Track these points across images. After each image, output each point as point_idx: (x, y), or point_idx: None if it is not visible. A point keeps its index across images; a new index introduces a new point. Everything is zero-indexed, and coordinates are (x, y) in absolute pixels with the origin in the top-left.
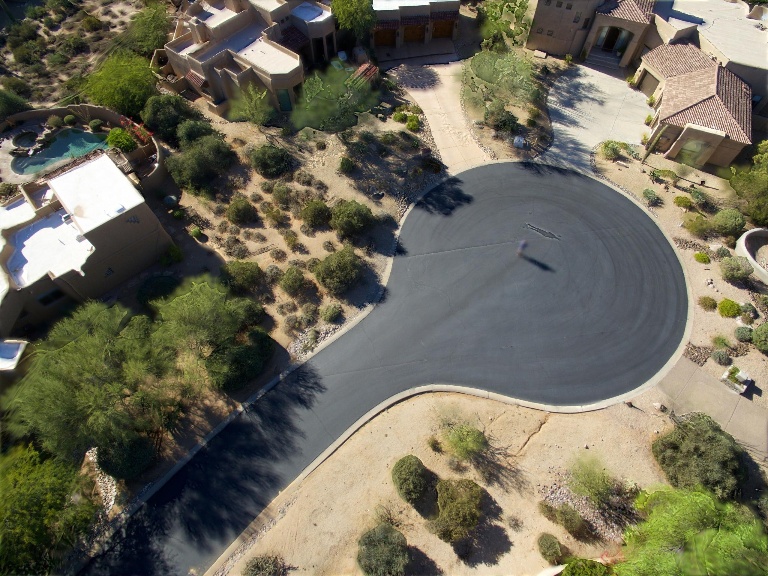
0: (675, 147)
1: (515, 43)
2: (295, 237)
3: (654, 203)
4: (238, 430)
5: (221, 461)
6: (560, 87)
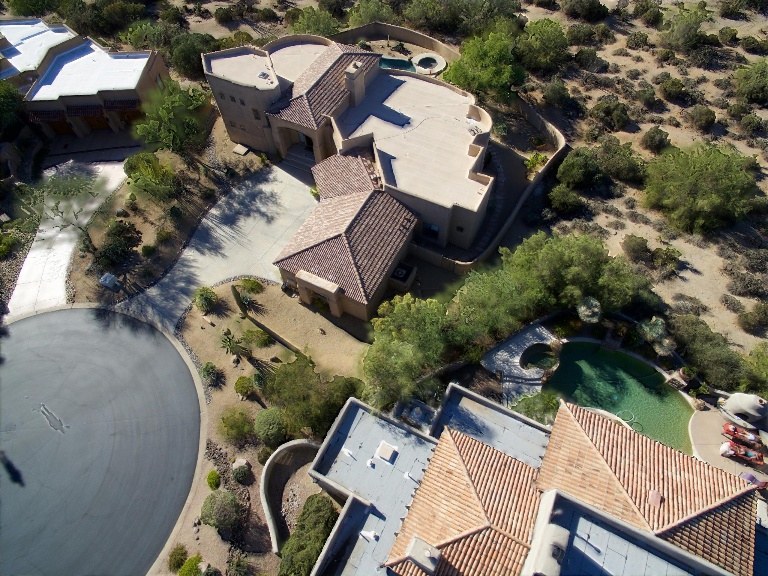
0: (301, 294)
1: (166, 147)
2: None
3: (215, 382)
4: None
5: None
6: (235, 195)
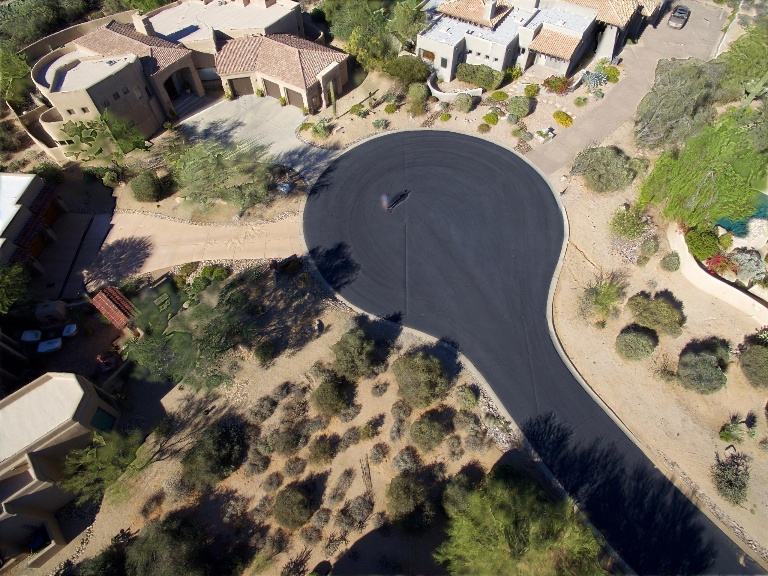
0: (325, 96)
1: None
2: (355, 431)
3: (385, 125)
4: (600, 512)
5: (634, 532)
6: (205, 145)
